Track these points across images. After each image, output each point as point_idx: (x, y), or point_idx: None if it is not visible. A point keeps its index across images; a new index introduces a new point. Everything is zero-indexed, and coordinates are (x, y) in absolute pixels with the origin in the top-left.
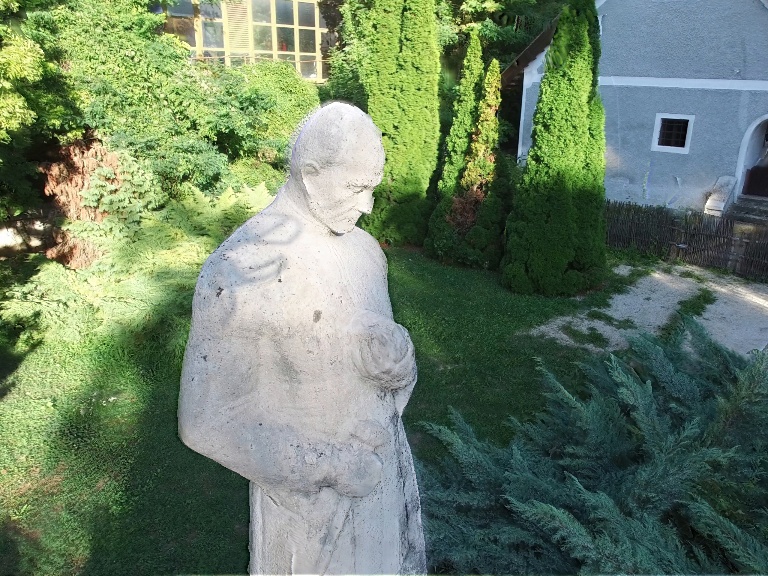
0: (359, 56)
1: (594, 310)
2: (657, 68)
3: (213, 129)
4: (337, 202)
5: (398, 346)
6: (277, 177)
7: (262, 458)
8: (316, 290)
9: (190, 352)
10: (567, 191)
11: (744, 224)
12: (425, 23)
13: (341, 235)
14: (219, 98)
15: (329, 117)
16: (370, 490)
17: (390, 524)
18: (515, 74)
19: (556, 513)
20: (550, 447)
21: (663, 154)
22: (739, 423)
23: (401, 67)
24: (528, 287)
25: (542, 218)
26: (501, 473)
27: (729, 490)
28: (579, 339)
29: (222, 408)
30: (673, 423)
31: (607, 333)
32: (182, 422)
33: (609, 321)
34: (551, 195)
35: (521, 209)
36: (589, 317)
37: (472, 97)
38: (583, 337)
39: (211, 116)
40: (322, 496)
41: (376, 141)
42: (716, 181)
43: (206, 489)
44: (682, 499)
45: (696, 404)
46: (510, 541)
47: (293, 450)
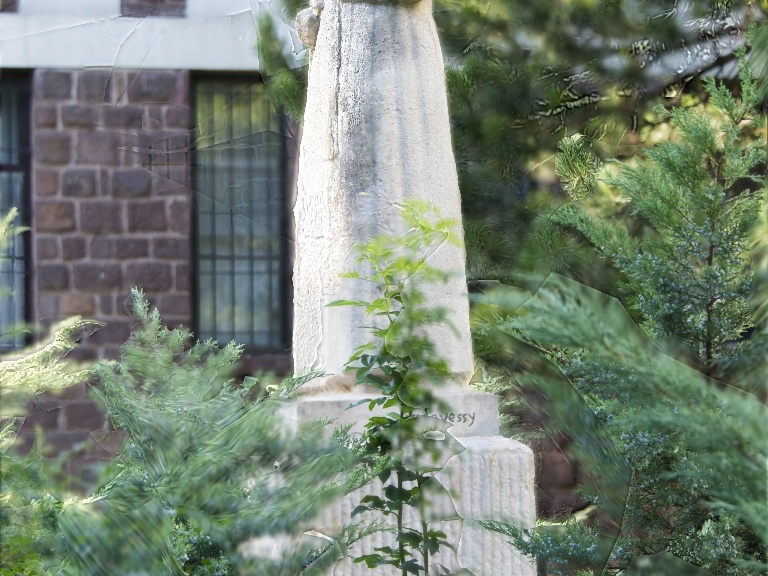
0: None
1: None
2: None
3: None
4: None
5: None
6: None
7: None
8: None
9: None
10: None
11: None
12: None
13: None
14: None
15: None
16: None
17: (324, 99)
18: None
19: None
20: None
21: None
22: None
23: None
24: None
25: None
26: None
27: None
28: None
29: None
30: None
31: None
32: None
33: None
34: None
35: None
36: None
37: None
38: None
39: None
40: None
41: None
42: None
43: None
44: None
45: None
46: None
47: None
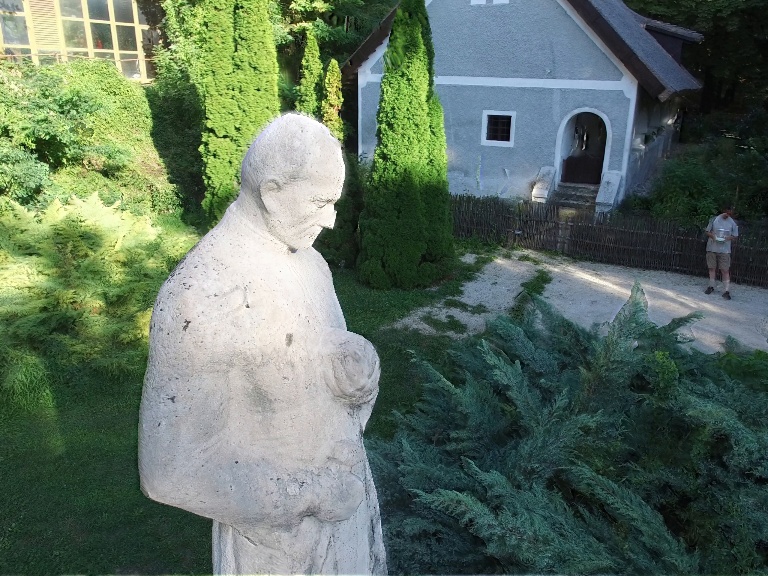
0: (187, 55)
1: (449, 299)
2: (480, 68)
3: (30, 136)
4: (301, 219)
5: (370, 361)
6: (109, 186)
7: (242, 498)
8: (284, 312)
9: (152, 395)
10: (415, 187)
11: (568, 209)
12: (259, 22)
13: (295, 252)
14: (34, 101)
15: (288, 130)
16: (353, 511)
17: (362, 541)
18: (349, 74)
19: (461, 498)
20: (433, 435)
21: (492, 148)
22: (600, 389)
23: (238, 67)
24: (386, 282)
25: (393, 214)
26: (392, 467)
27: (600, 451)
28: (440, 328)
29: (195, 451)
30: (543, 397)
31: (464, 319)
32: (148, 473)
33: (464, 308)
34: (400, 191)
35: (373, 206)
36: (446, 306)
37: (313, 97)
38: (443, 325)
39: (26, 121)
40: (303, 526)
41: (337, 154)
42: (539, 171)
43: (75, 536)
44: (562, 465)
45: (556, 376)
46: (412, 532)
47: (274, 484)
